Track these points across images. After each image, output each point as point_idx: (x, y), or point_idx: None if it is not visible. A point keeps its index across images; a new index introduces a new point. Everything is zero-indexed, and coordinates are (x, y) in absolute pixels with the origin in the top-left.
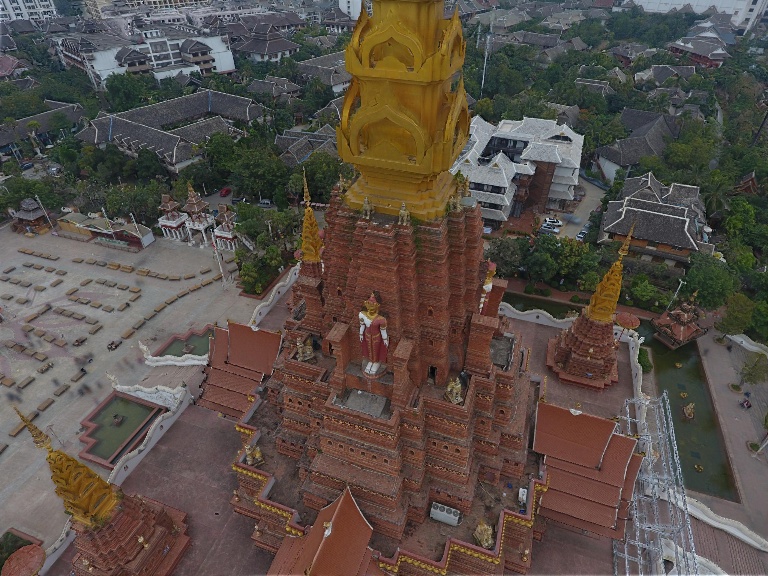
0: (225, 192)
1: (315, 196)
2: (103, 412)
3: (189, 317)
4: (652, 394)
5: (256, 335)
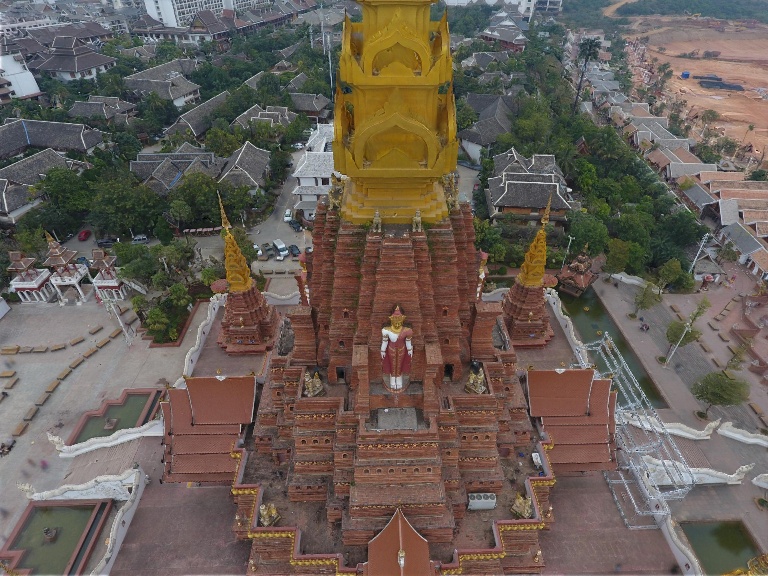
0: (84, 235)
1: (197, 221)
2: (25, 532)
3: (96, 388)
4: (577, 339)
5: (223, 384)
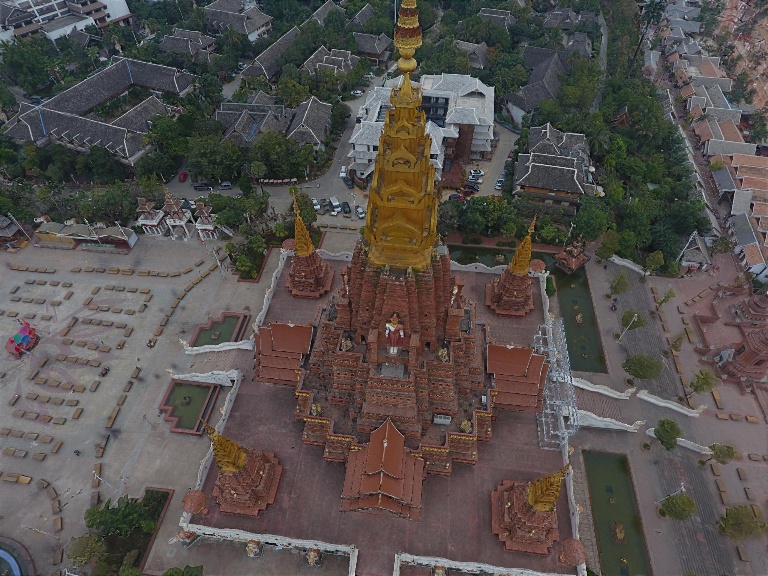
0: (183, 177)
1: (270, 171)
2: (171, 397)
3: (203, 308)
4: (556, 311)
5: (293, 329)
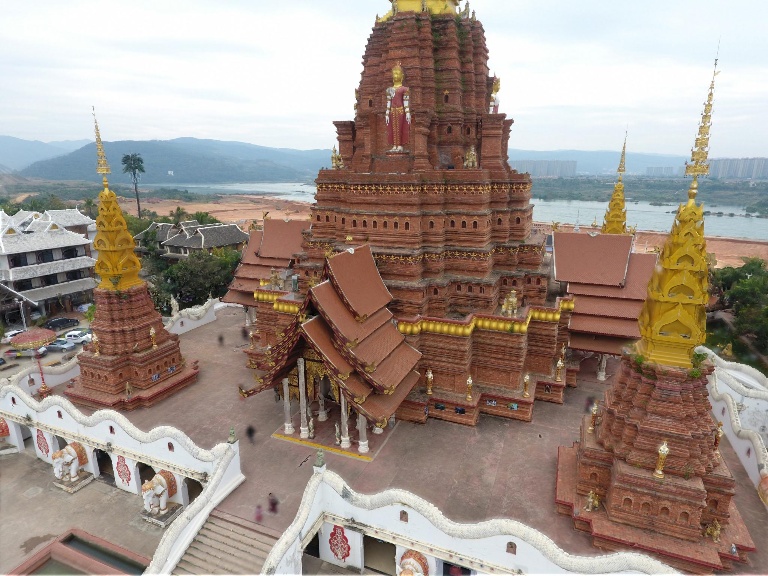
0: None
1: None
2: None
3: None
4: None
5: (354, 260)
